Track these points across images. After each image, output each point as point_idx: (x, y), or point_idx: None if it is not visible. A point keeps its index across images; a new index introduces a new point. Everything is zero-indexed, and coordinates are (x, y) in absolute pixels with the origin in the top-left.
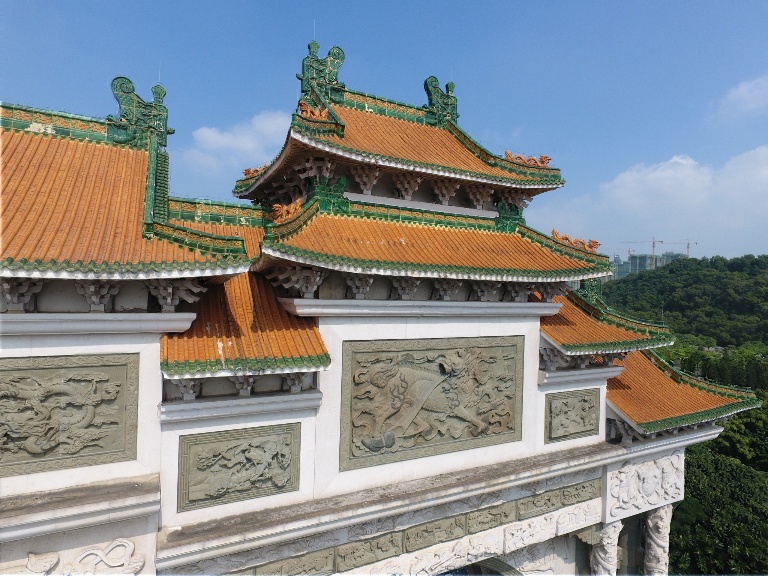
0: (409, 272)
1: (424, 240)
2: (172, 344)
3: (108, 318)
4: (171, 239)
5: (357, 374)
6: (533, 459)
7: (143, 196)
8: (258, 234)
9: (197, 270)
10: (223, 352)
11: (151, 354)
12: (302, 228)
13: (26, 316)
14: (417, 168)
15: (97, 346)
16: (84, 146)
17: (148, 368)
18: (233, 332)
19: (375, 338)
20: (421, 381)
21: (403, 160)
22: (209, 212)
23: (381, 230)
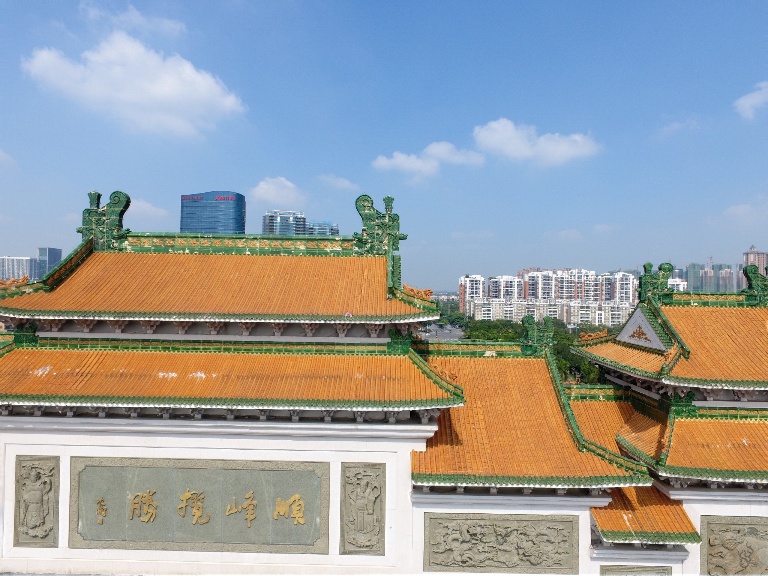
0: (758, 480)
1: (763, 439)
2: (598, 514)
3: (569, 500)
4: (595, 453)
5: (712, 539)
6: None
7: (558, 405)
8: (613, 409)
9: (622, 484)
10: (630, 524)
11: (585, 517)
12: (671, 440)
13: (534, 498)
14: (756, 388)
15: (559, 511)
16: (512, 362)
17: (584, 524)
18: (629, 506)
19: (725, 514)
20: (764, 549)
21: (744, 383)
22: (579, 393)
23: (725, 431)
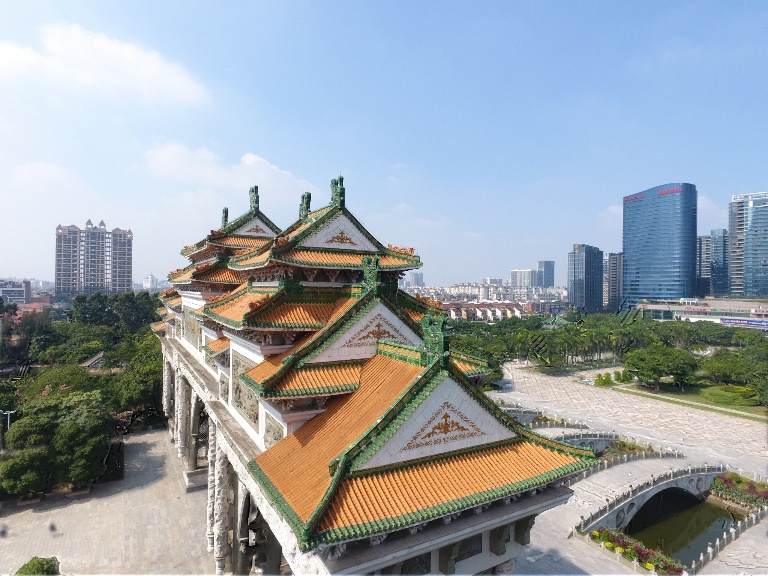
0: None
1: None
2: None
3: None
4: None
5: None
6: (256, 450)
7: None
8: None
9: None
10: None
11: None
12: (229, 302)
13: None
14: None
15: None
16: None
17: None
18: None
19: None
20: None
21: None
22: None
23: None
